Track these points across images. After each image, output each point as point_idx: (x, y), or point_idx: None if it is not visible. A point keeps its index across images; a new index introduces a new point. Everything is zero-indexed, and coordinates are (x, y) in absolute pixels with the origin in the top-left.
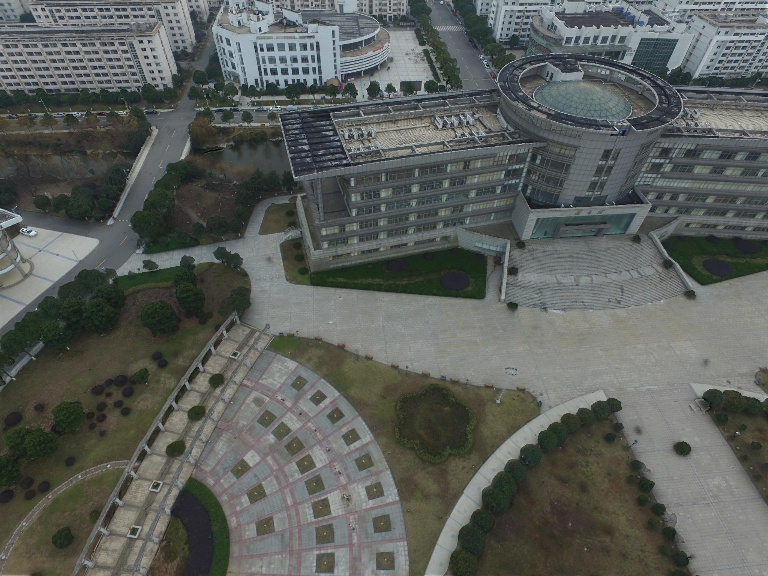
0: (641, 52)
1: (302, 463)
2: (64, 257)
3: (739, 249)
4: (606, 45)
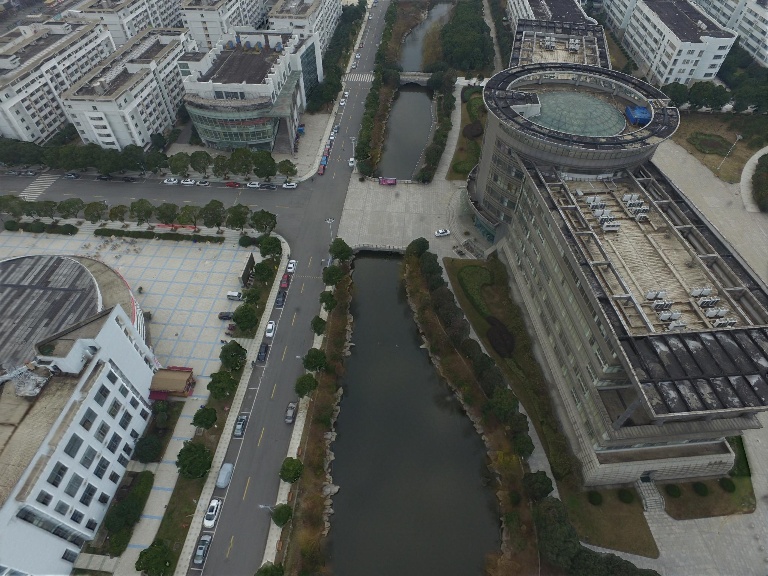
0: (304, 69)
1: None
2: None
3: None
4: (287, 80)
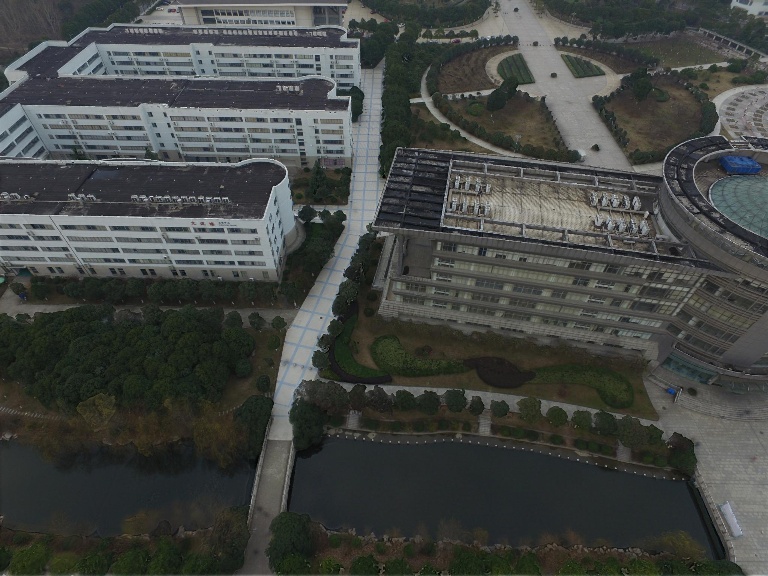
0: None
1: None
2: None
3: None
4: None
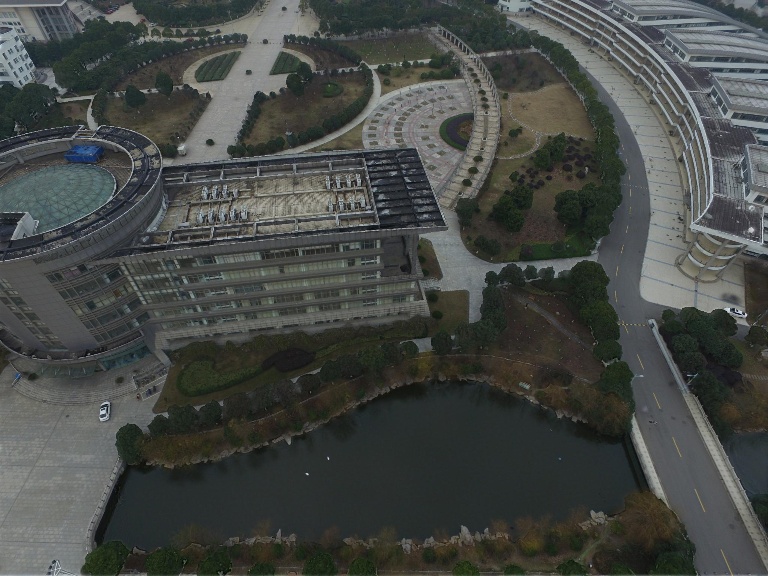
0: None
1: None
2: (662, 281)
3: None
4: None
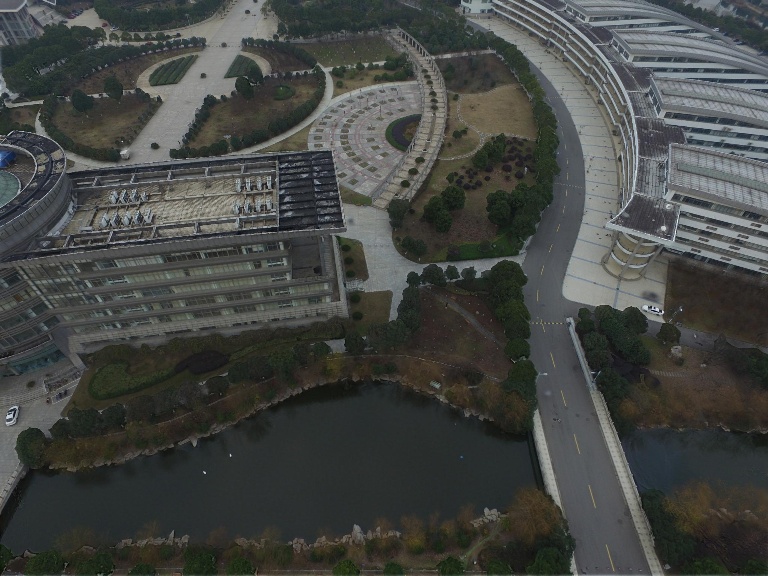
0: None
1: (353, 154)
2: (586, 280)
3: None
4: None
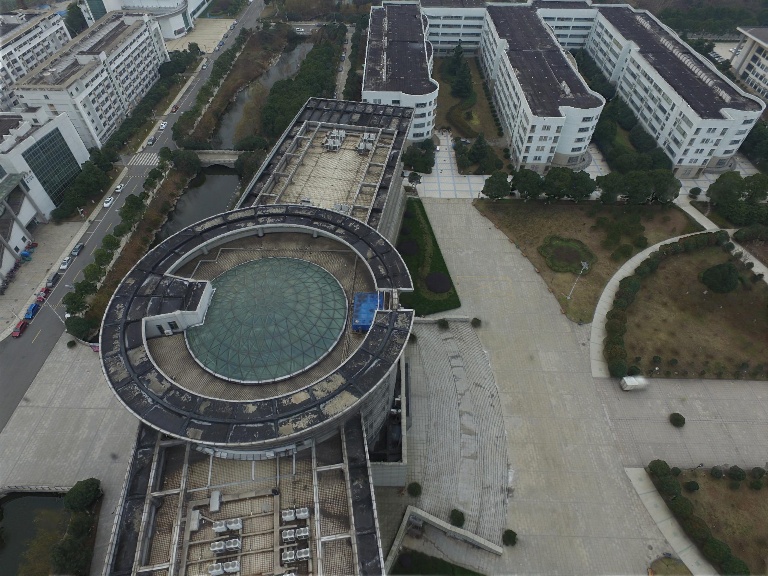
0: (37, 167)
1: None
2: None
3: (413, 255)
4: None
